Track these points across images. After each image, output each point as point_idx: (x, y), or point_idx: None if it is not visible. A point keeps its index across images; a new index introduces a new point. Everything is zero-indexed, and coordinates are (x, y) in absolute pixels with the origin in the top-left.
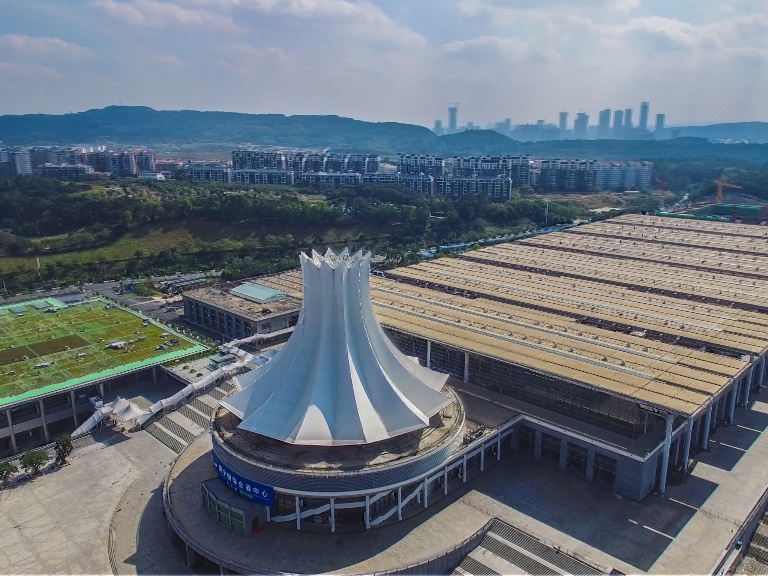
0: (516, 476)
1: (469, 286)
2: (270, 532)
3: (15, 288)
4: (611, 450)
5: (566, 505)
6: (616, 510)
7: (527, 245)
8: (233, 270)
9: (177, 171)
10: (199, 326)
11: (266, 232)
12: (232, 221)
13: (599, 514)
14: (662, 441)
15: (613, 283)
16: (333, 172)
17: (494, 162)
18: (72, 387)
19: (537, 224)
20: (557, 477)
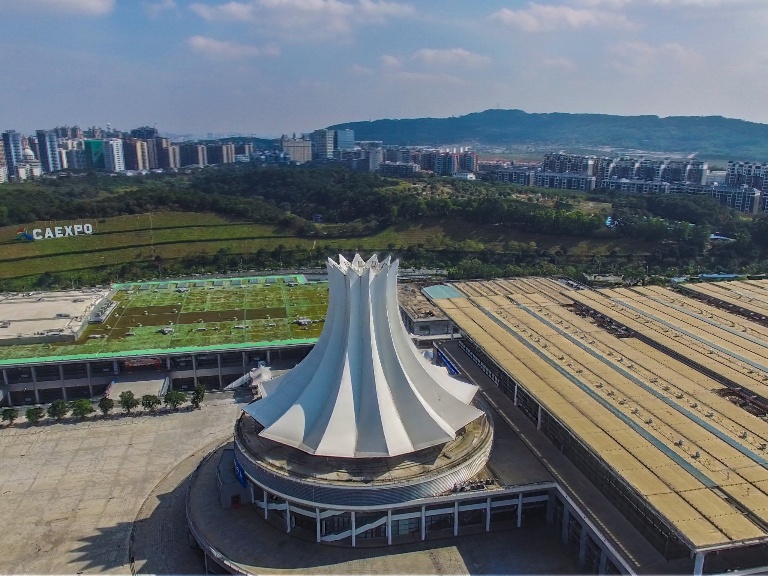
0: (517, 550)
1: (635, 322)
2: (244, 512)
3: (289, 263)
4: (619, 560)
5: None
6: None
7: None
8: (458, 271)
9: (489, 172)
10: None
11: (514, 237)
12: (486, 223)
13: None
14: (702, 575)
15: None
16: (638, 179)
17: None
18: (240, 349)
19: None
20: (565, 570)
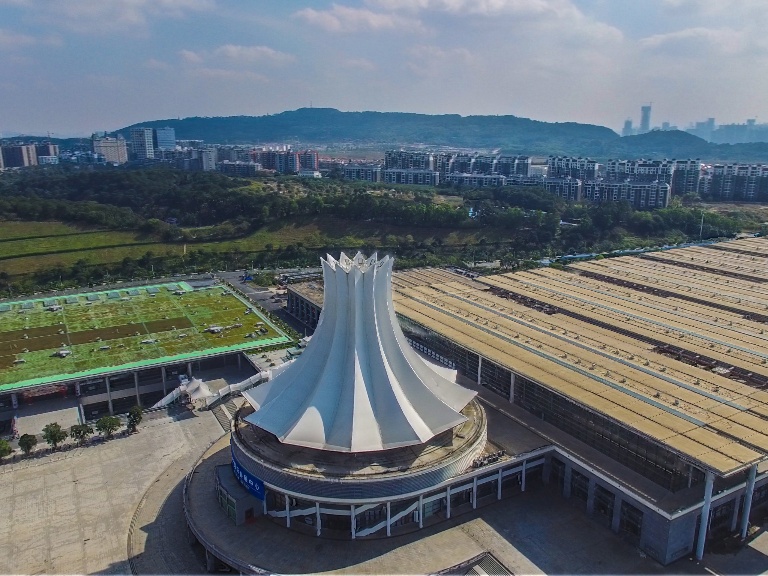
0: (533, 511)
1: (553, 300)
2: (261, 525)
3: (161, 271)
4: (638, 500)
5: (574, 553)
6: (631, 569)
7: (651, 259)
8: None
9: (333, 170)
10: (296, 318)
11: (389, 231)
12: (359, 219)
13: (608, 570)
14: None
15: (728, 309)
16: (477, 174)
17: (653, 166)
18: (161, 364)
19: (688, 236)
20: (580, 520)
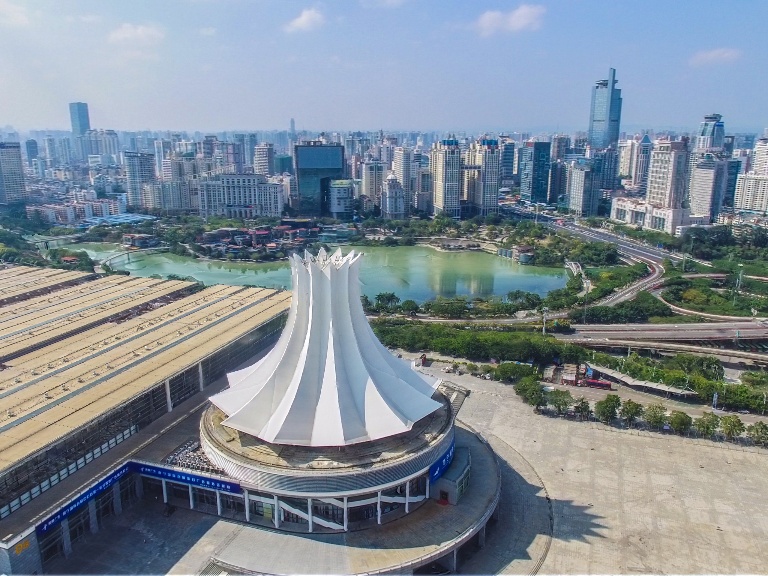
0: None
1: None
2: None
3: None
4: None
5: None
6: None
7: None
8: None
9: None
10: None
11: None
12: None
13: None
14: None
15: None
16: None
17: None
18: None
19: None
20: None
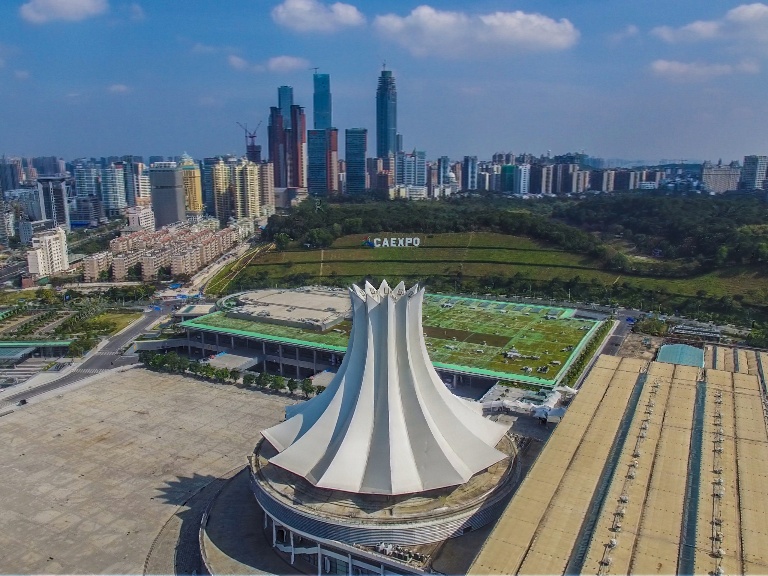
0: None
1: None
2: None
3: (578, 296)
4: None
5: None
6: None
7: None
8: (760, 335)
9: None
10: None
11: None
12: None
13: None
14: None
15: None
16: None
17: None
18: None
19: None
20: None
